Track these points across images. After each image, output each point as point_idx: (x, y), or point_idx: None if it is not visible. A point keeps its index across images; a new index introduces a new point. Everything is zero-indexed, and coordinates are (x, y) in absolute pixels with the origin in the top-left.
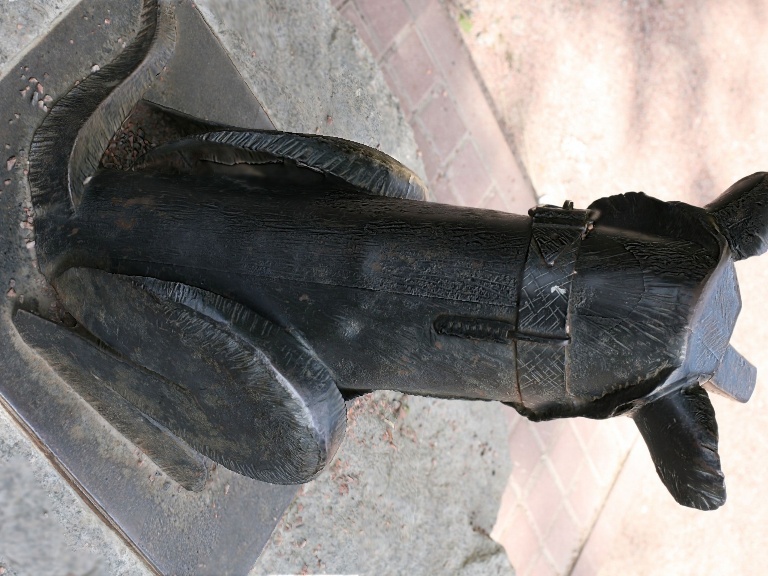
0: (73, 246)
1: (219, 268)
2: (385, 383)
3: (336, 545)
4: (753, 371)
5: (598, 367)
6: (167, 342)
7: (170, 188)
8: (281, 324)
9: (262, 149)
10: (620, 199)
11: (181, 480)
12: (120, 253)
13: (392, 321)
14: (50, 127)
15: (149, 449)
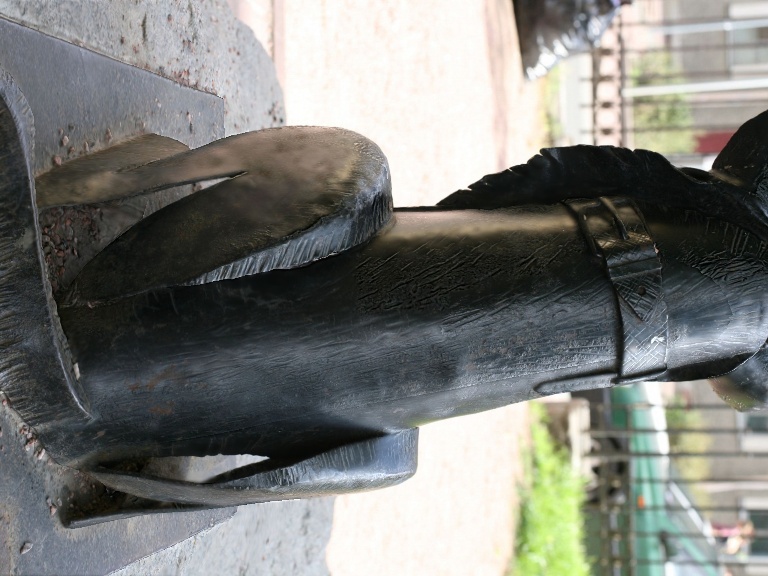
0: (105, 445)
1: (296, 416)
2: None
3: None
4: None
5: None
6: None
7: (186, 346)
8: (374, 431)
9: None
10: (628, 155)
11: None
12: (171, 437)
13: (491, 397)
14: (8, 348)
15: None
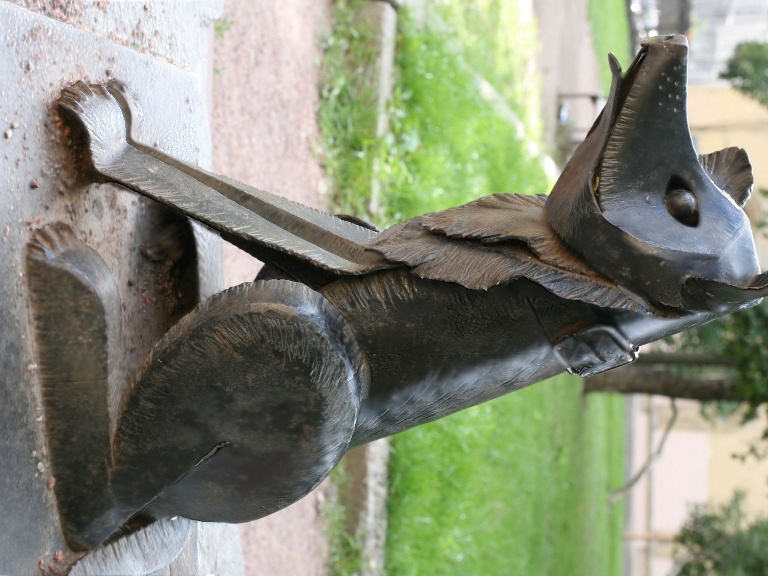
0: None
1: None
2: None
3: None
4: None
5: None
6: None
7: None
8: None
9: None
10: None
11: None
12: None
13: None
14: None
15: None
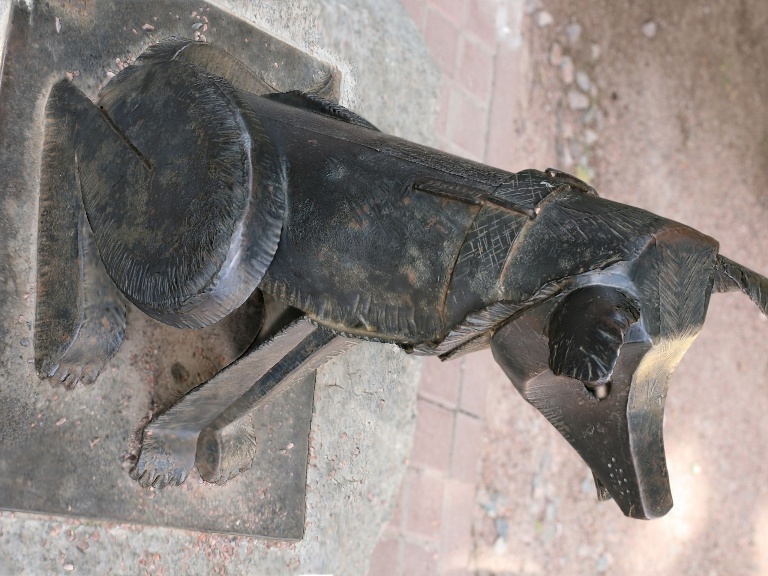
0: None
1: (256, 112)
2: (328, 242)
3: None
4: (669, 502)
5: (547, 251)
6: (174, 112)
7: None
8: (277, 152)
9: (344, 114)
10: None
11: (41, 347)
12: None
13: (378, 173)
14: None
15: (46, 287)
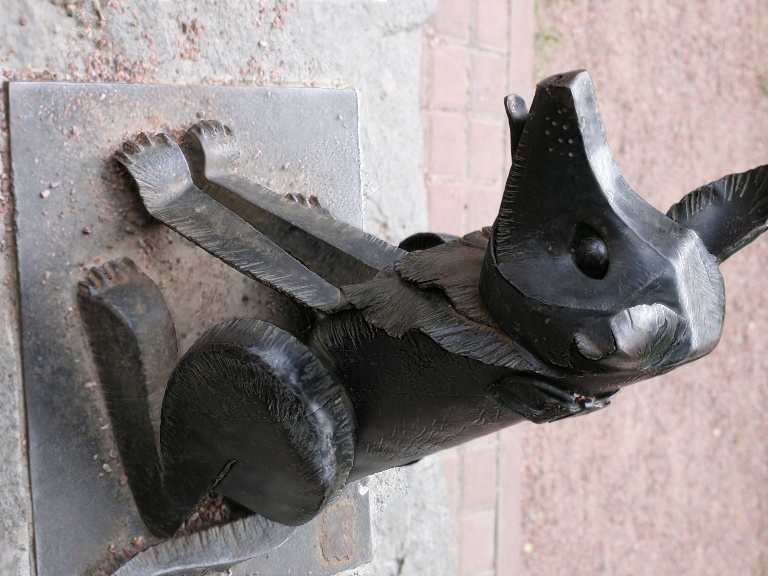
0: None
1: None
2: None
3: (243, 4)
4: (574, 91)
5: None
6: None
7: None
8: None
9: None
10: None
11: None
12: None
13: None
14: None
15: None
